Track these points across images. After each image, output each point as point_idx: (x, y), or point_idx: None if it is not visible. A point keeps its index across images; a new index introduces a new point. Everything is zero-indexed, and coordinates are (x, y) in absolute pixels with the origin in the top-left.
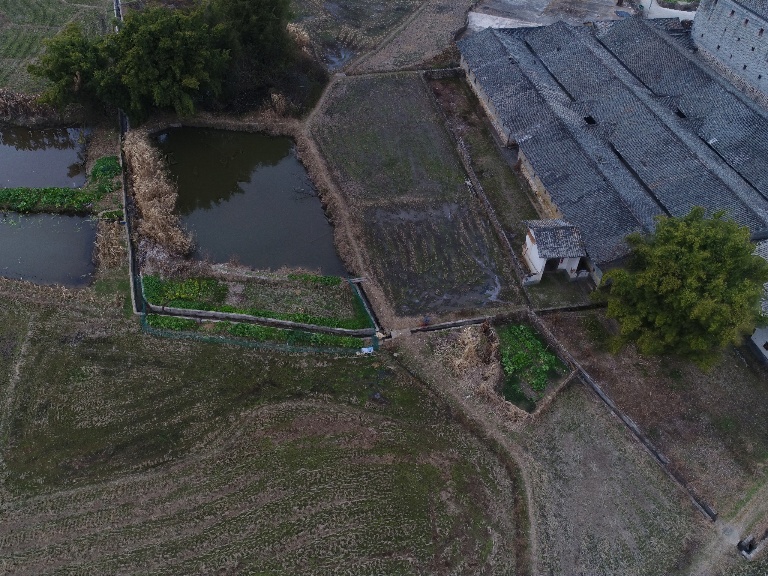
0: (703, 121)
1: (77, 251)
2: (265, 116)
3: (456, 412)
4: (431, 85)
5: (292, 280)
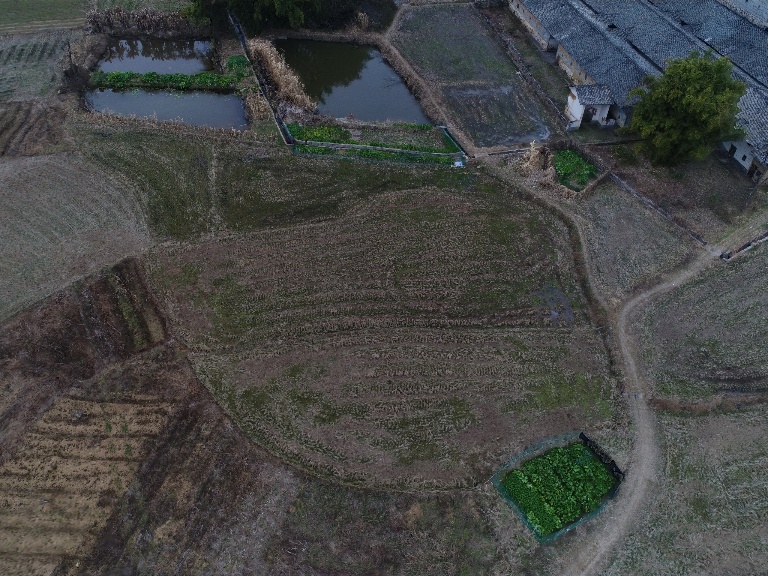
0: (701, 27)
1: (231, 112)
2: (353, 31)
3: (526, 195)
4: None
5: (396, 127)
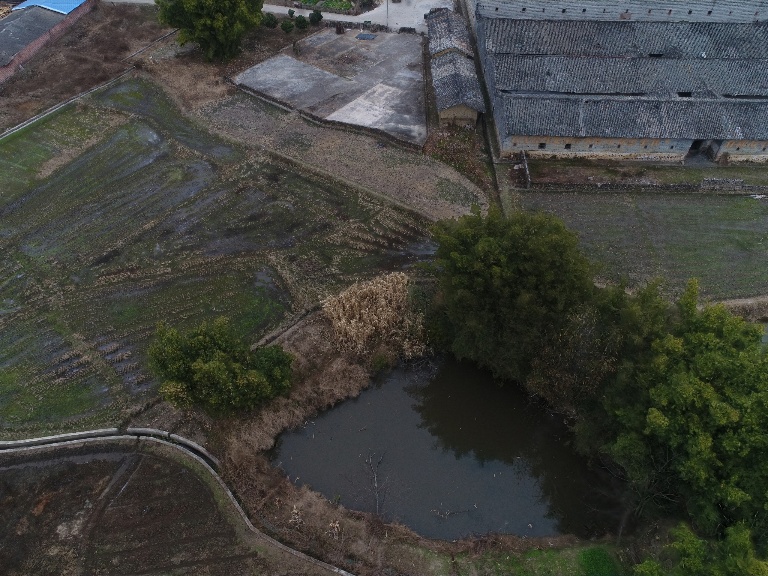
0: (678, 49)
1: None
2: None
3: None
4: None
5: None
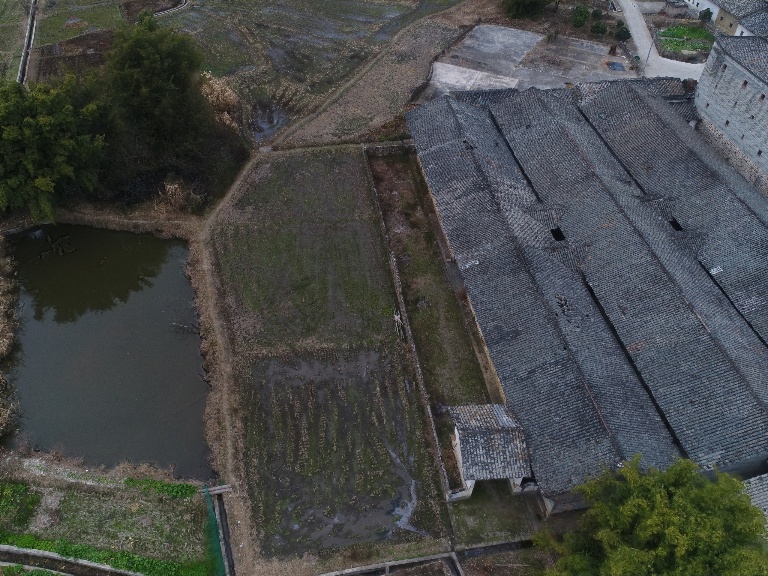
0: (704, 239)
1: None
2: (158, 211)
3: None
4: (373, 165)
5: (129, 488)
